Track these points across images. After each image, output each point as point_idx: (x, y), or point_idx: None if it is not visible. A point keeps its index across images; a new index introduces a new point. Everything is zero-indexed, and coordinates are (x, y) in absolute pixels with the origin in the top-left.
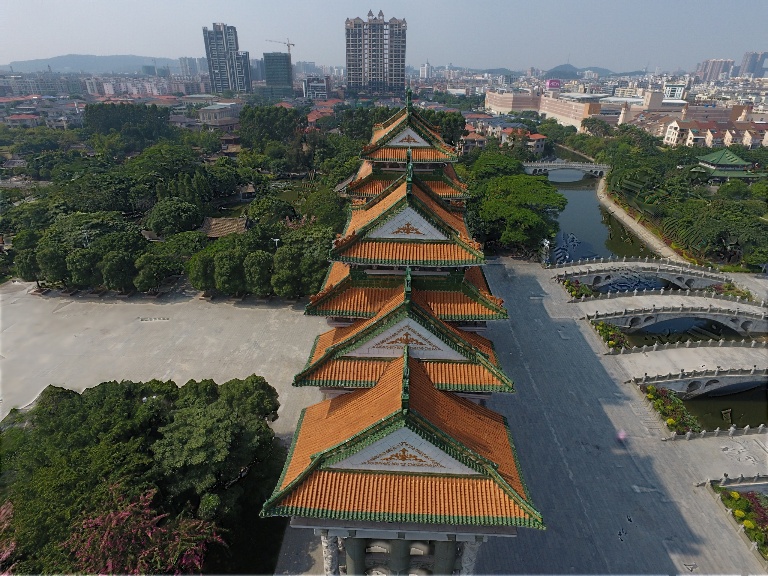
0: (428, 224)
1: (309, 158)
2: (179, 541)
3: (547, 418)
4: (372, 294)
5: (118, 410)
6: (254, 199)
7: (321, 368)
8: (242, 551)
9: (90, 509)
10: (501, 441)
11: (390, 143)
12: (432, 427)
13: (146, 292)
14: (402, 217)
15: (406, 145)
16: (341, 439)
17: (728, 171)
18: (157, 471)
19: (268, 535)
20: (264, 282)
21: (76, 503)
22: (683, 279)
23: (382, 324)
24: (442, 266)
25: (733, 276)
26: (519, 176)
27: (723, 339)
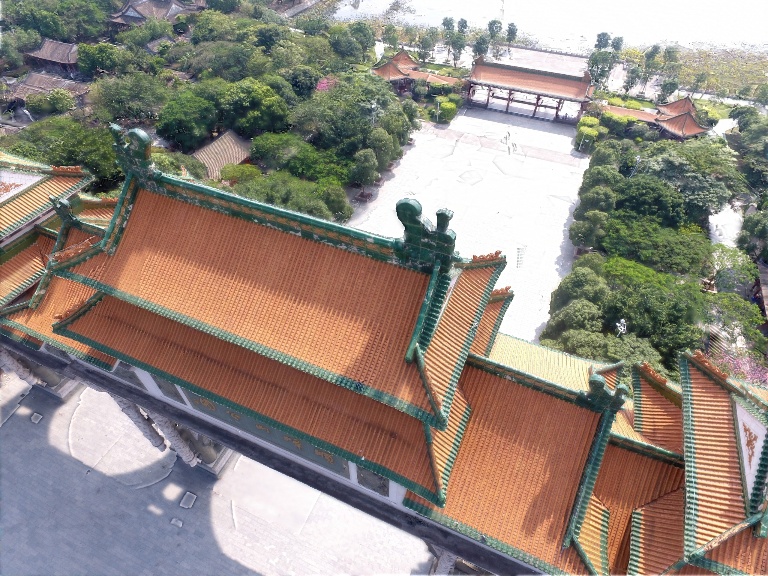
0: None
1: None
2: None
3: None
4: None
5: None
6: None
7: None
8: None
9: None
10: None
11: None
12: None
13: None
14: None
15: None
16: None
17: None
18: None
19: None
20: (551, 336)
21: None
22: None
23: None
24: None
25: None
26: None
27: None
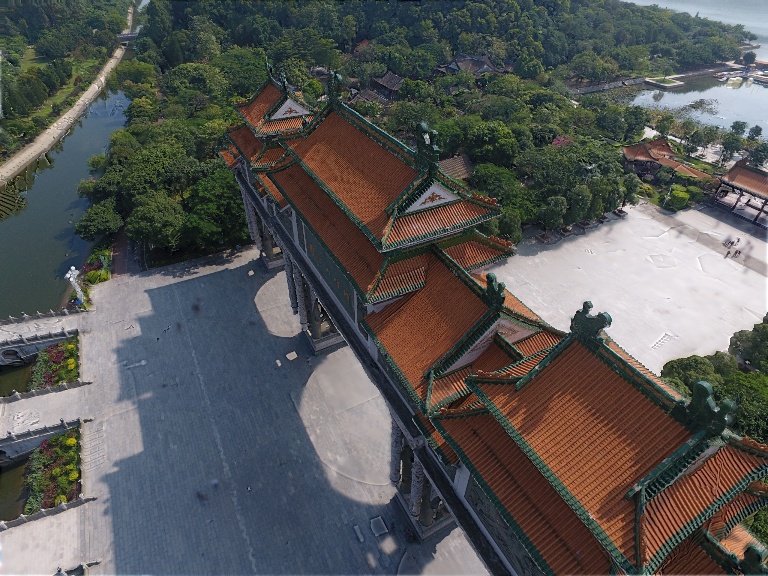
0: None
1: None
2: None
3: (207, 398)
4: None
5: None
6: None
7: None
8: None
9: None
10: None
11: None
12: None
13: (758, 370)
14: None
15: None
16: None
17: None
18: None
19: None
20: None
21: None
22: None
23: None
24: None
25: None
26: None
27: None
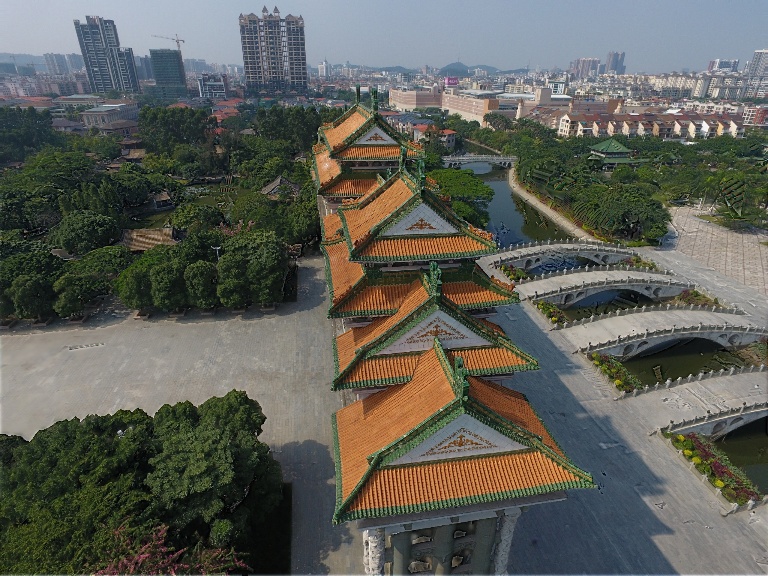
0: (440, 218)
1: (224, 161)
2: (207, 574)
3: None
4: (389, 291)
5: (96, 448)
6: (178, 207)
7: (354, 370)
8: (251, 574)
9: (93, 560)
10: (530, 416)
11: (358, 142)
12: (487, 410)
13: (68, 317)
14: (416, 213)
15: (374, 143)
16: (393, 436)
17: (615, 158)
18: (157, 506)
19: (275, 553)
20: (209, 294)
21: (76, 556)
22: (600, 256)
23: (412, 319)
24: (458, 258)
25: (638, 250)
26: (446, 170)
27: (645, 305)
